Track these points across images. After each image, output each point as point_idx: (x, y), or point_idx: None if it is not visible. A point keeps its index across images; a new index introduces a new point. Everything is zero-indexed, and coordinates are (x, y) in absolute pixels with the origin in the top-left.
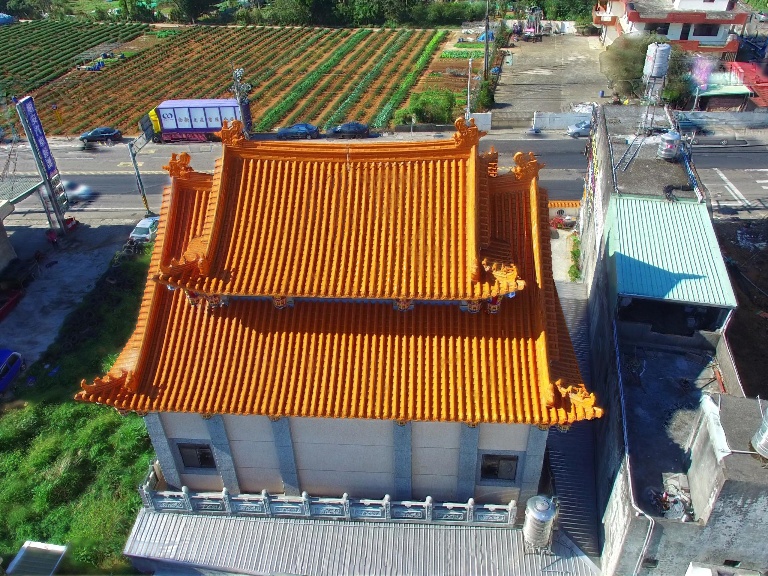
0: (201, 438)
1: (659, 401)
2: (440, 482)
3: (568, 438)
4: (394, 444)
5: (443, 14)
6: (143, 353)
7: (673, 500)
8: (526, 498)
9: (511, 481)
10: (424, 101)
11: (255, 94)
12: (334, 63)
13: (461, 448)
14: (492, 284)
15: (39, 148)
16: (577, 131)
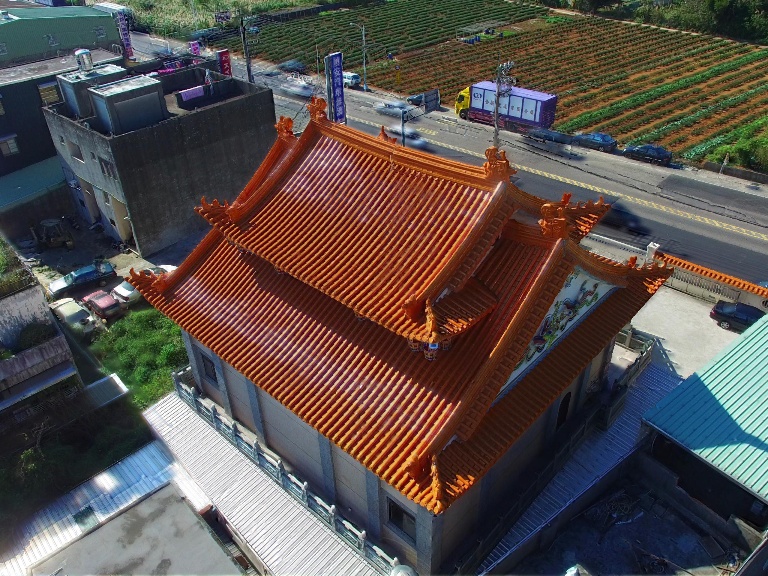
0: (211, 355)
1: (605, 561)
2: (358, 501)
3: None
4: (318, 439)
5: None
6: (183, 267)
7: None
8: (422, 568)
9: (413, 541)
10: (755, 142)
11: (587, 94)
12: (700, 79)
13: (366, 476)
14: (418, 326)
15: (334, 97)
16: None
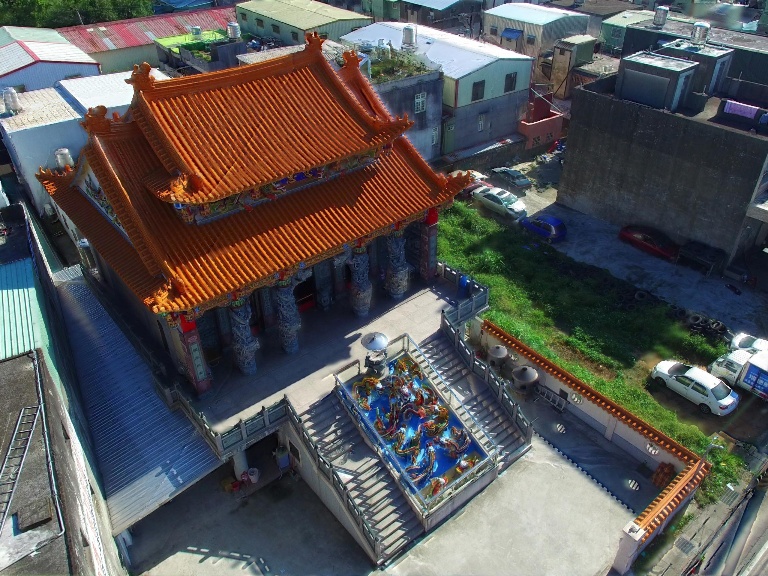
0: None
1: None
2: None
3: (91, 332)
4: None
5: None
6: None
7: (0, 226)
8: None
9: None
10: None
11: None
12: None
13: None
14: None
15: None
16: None
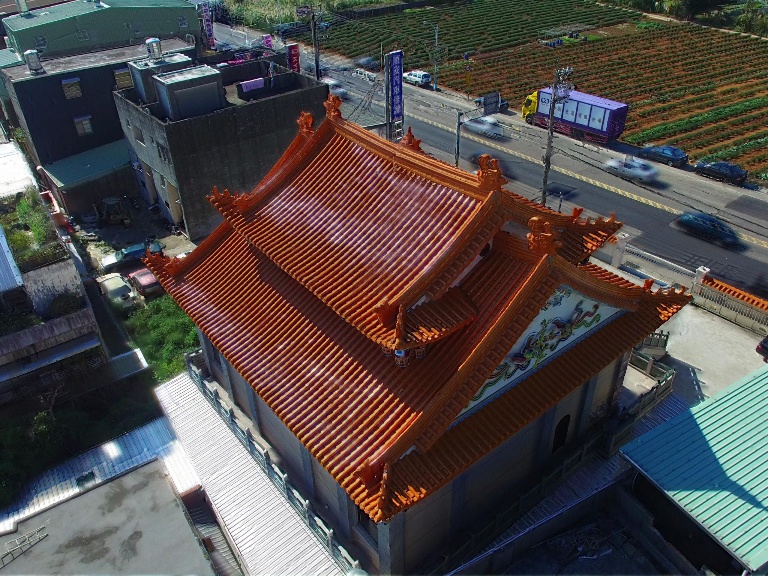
0: None
1: None
2: (333, 499)
3: None
4: None
5: None
6: (196, 252)
7: None
8: (384, 574)
9: None
10: None
11: (665, 104)
12: None
13: None
14: (388, 331)
15: (392, 95)
16: None
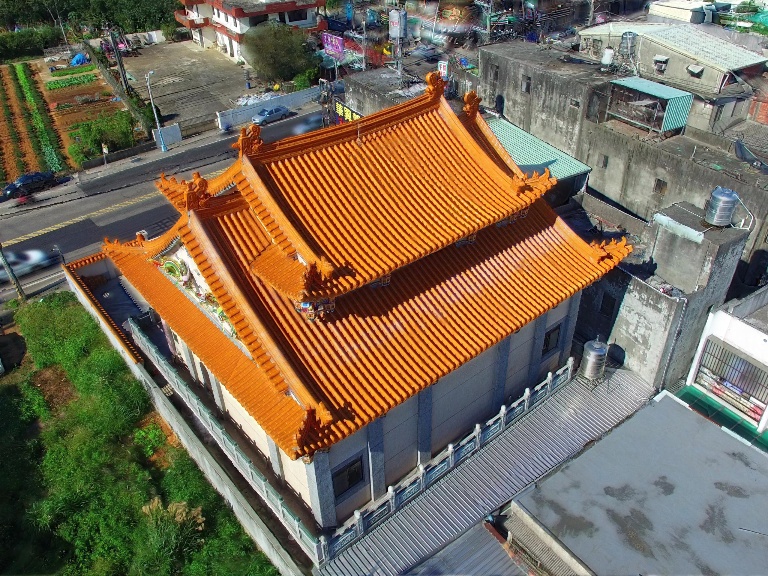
0: (357, 452)
1: None
2: (518, 378)
3: None
4: (500, 358)
5: (8, 46)
6: (305, 387)
7: None
8: (566, 356)
9: (556, 348)
10: (101, 130)
11: None
12: None
13: (537, 335)
14: (531, 190)
15: None
16: (263, 119)
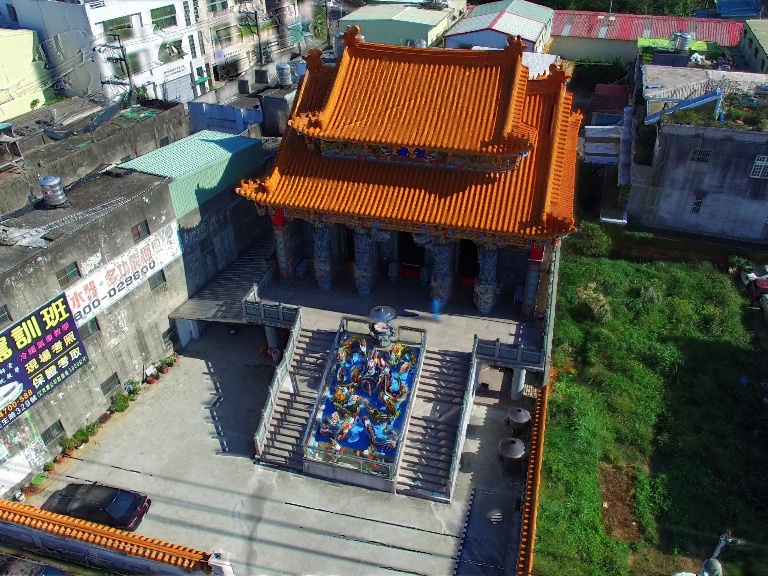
0: None
1: None
2: None
3: None
4: None
5: None
6: None
7: None
8: None
9: None
10: None
11: None
12: None
13: None
14: None
15: None
16: None
